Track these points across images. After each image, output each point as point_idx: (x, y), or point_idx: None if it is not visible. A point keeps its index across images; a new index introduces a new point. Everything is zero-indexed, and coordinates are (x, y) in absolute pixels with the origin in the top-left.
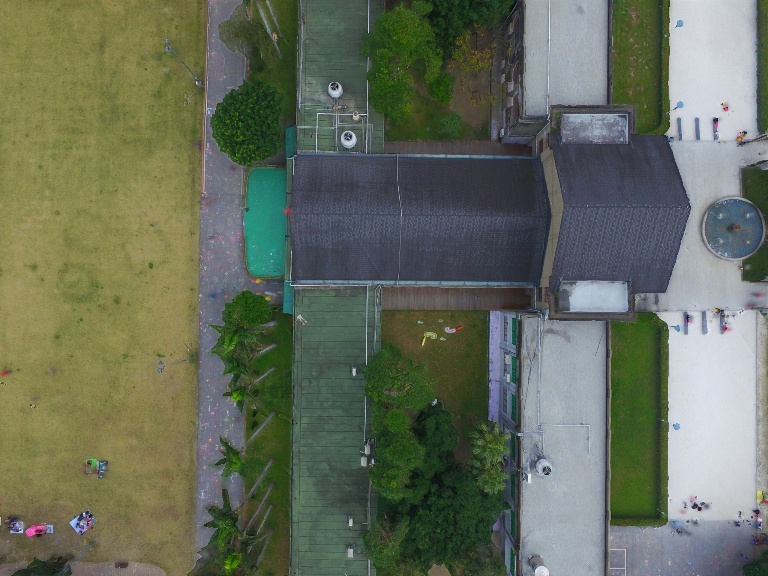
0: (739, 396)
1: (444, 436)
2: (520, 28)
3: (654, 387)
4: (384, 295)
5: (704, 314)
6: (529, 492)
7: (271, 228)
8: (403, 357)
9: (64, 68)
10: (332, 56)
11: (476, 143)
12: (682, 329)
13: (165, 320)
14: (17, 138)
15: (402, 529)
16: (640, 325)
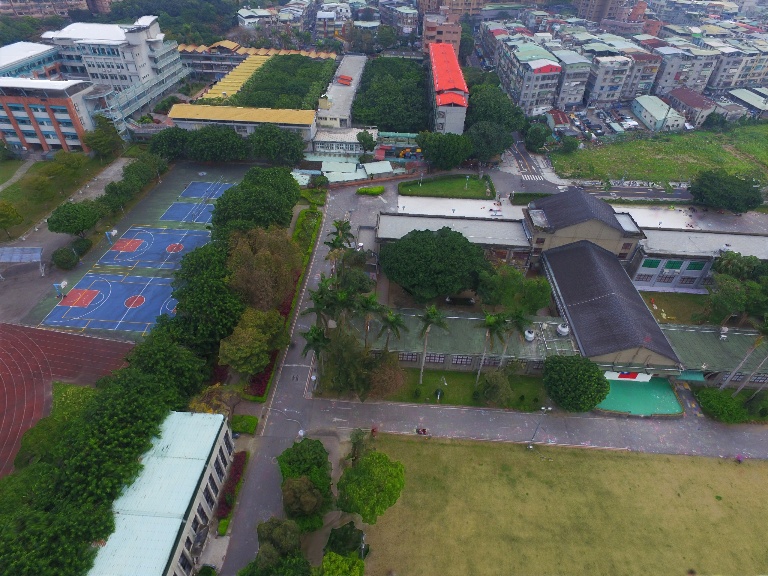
0: None
1: None
2: None
3: None
4: None
5: None
6: None
7: (637, 396)
8: None
9: None
10: None
11: None
12: None
13: (763, 488)
14: None
15: None
16: None
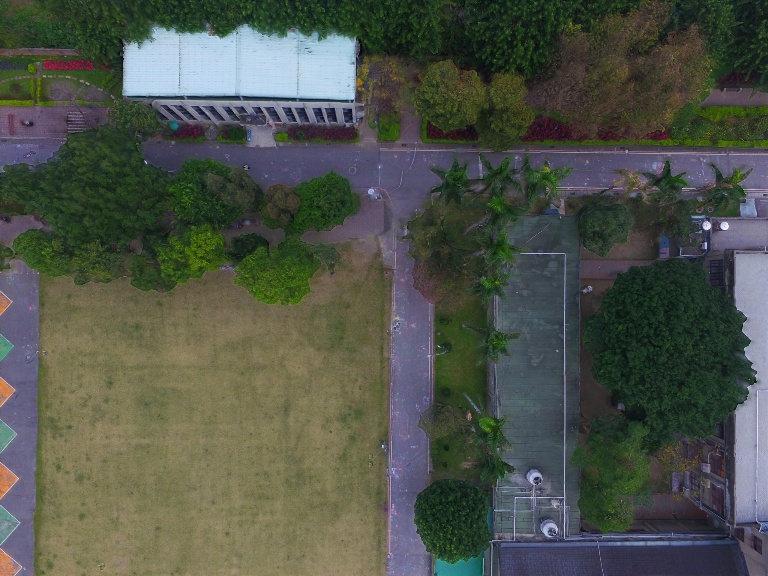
0: None
1: None
2: (727, 432)
3: None
4: None
5: None
6: None
7: None
8: None
9: (249, 433)
10: (528, 438)
11: (658, 496)
12: None
13: None
14: (203, 505)
15: None
16: None
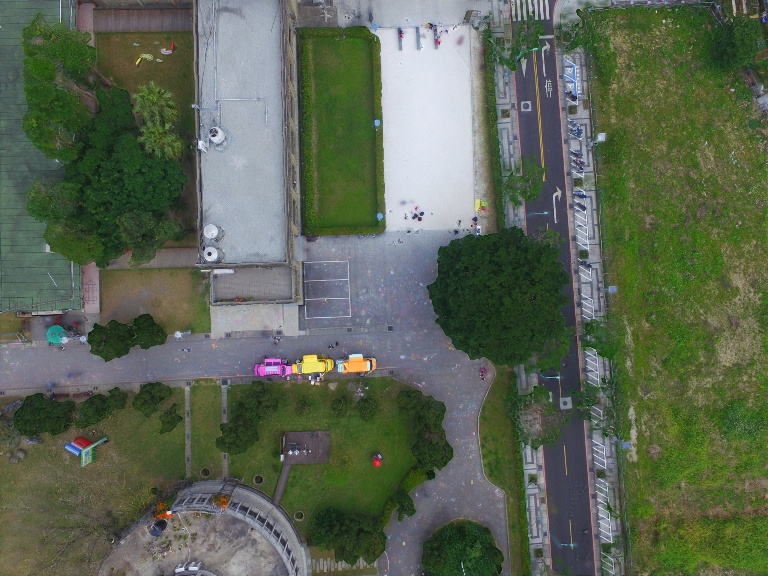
0: (456, 109)
1: (118, 109)
2: None
3: (371, 103)
4: (98, 18)
5: (417, 29)
6: (209, 166)
7: None
8: (120, 79)
9: None
10: None
11: None
12: (397, 45)
13: None
14: None
15: (61, 184)
16: (355, 42)
